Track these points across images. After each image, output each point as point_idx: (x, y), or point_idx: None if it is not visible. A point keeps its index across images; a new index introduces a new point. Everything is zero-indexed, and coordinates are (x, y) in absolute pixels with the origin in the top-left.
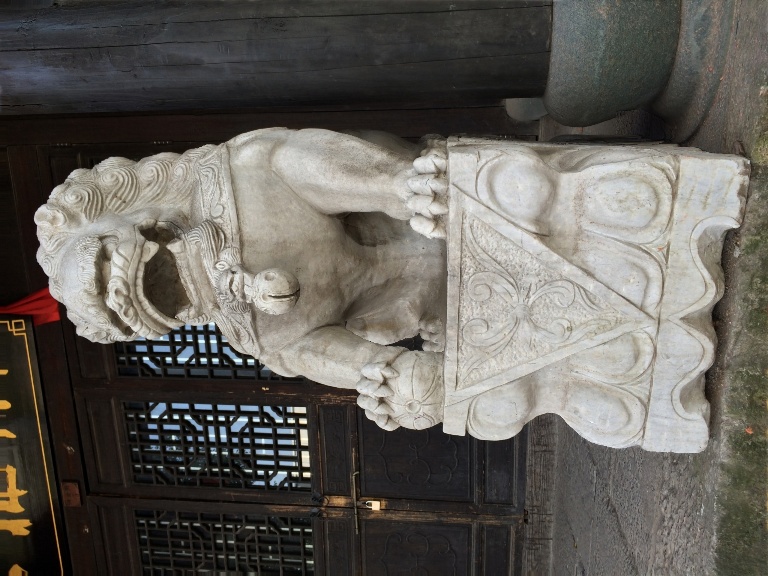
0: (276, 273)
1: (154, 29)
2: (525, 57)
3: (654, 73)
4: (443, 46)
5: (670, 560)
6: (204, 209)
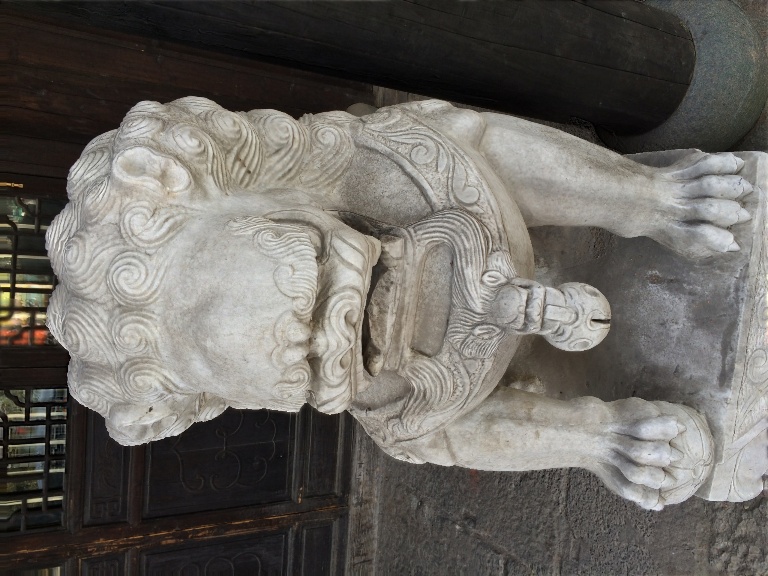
0: None
1: None
2: (671, 85)
3: (750, 125)
4: (617, 53)
5: None
6: (434, 192)
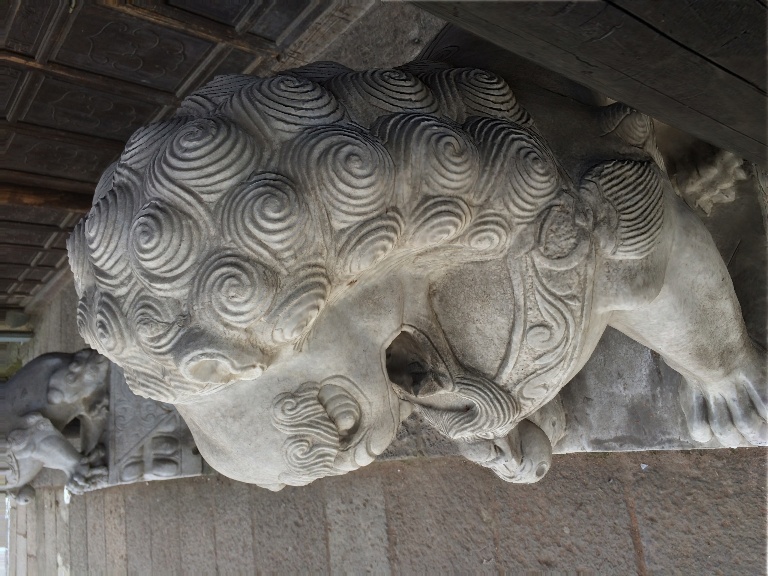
0: (548, 464)
1: (767, 35)
2: None
3: None
4: None
5: None
6: (512, 372)
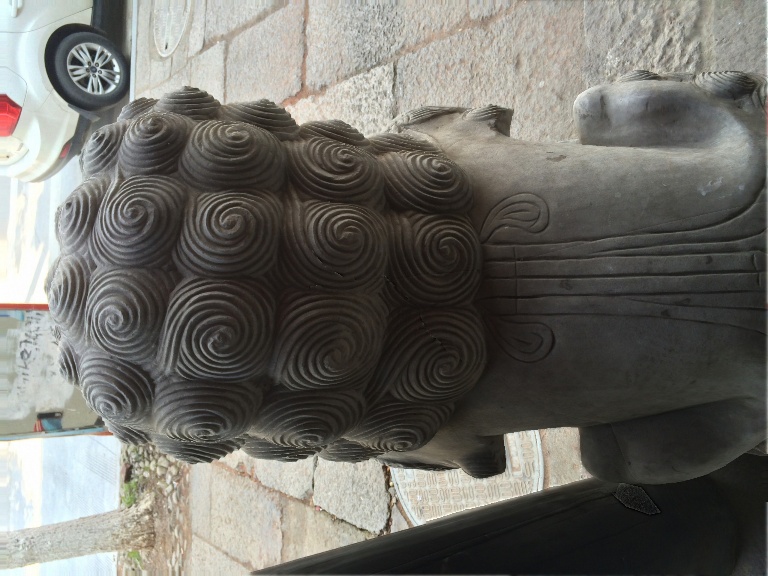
0: None
1: None
2: None
3: None
4: None
5: (660, 26)
6: None
